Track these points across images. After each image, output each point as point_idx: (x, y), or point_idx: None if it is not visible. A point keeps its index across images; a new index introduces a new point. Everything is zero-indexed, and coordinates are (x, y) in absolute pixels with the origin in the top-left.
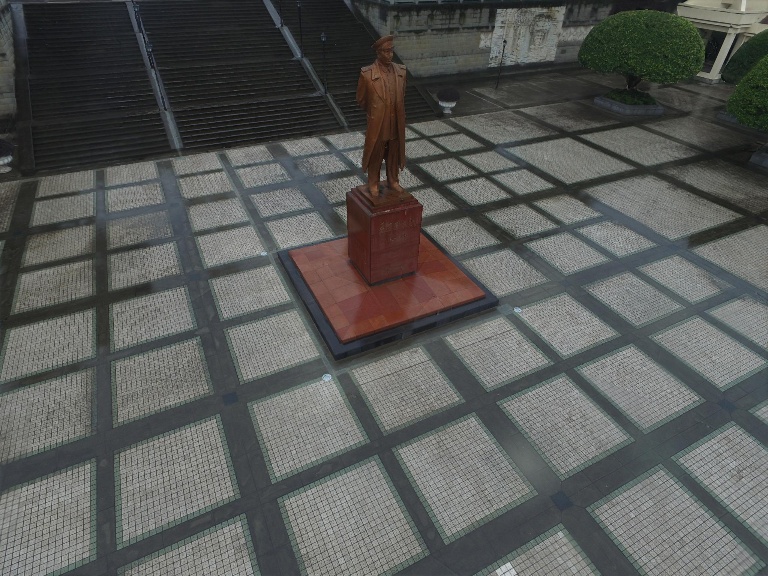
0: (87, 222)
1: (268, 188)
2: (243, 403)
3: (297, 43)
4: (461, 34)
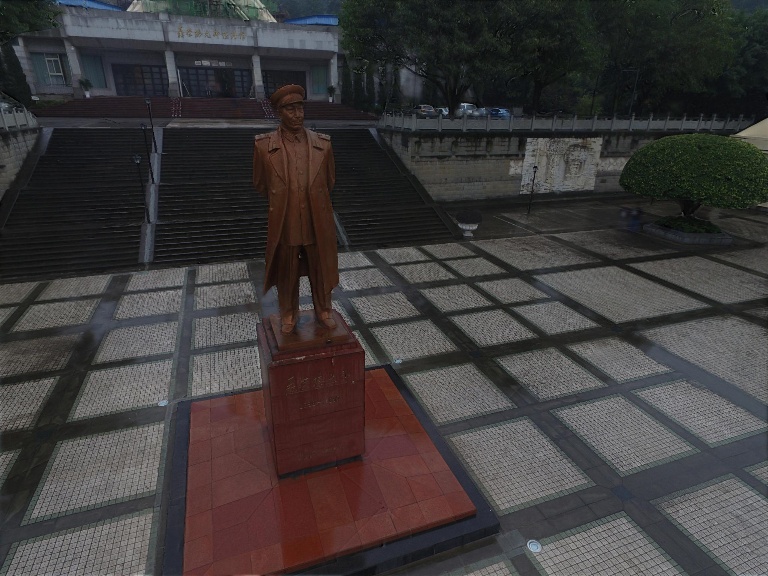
0: None
1: (222, 311)
2: None
3: None
4: (488, 161)
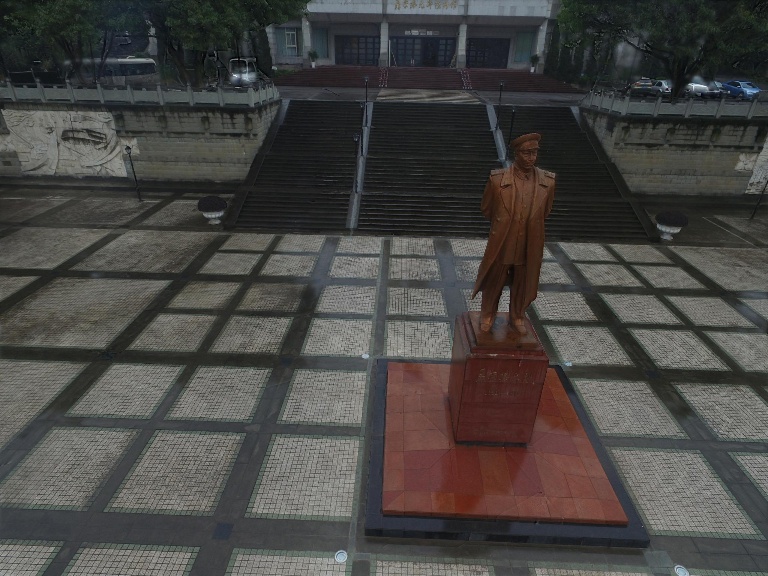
0: (238, 279)
1: (411, 284)
2: (231, 545)
3: (506, 146)
4: (711, 152)
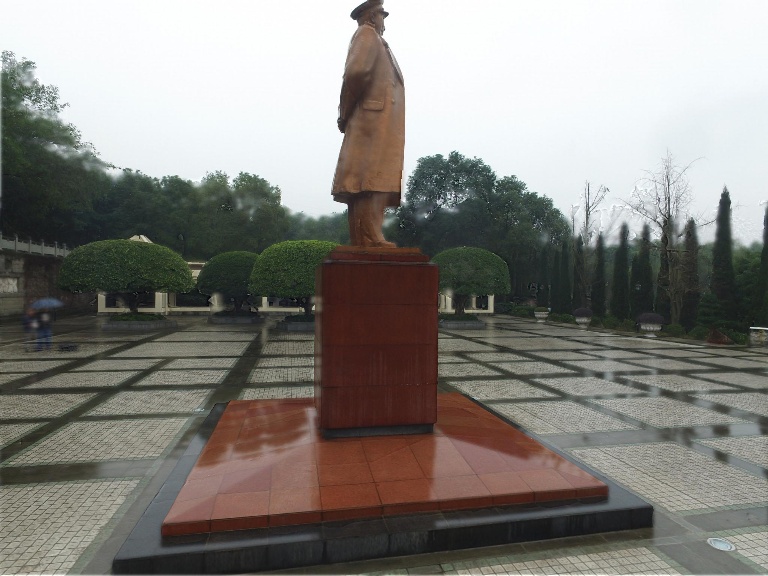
0: None
1: None
2: None
3: None
4: None
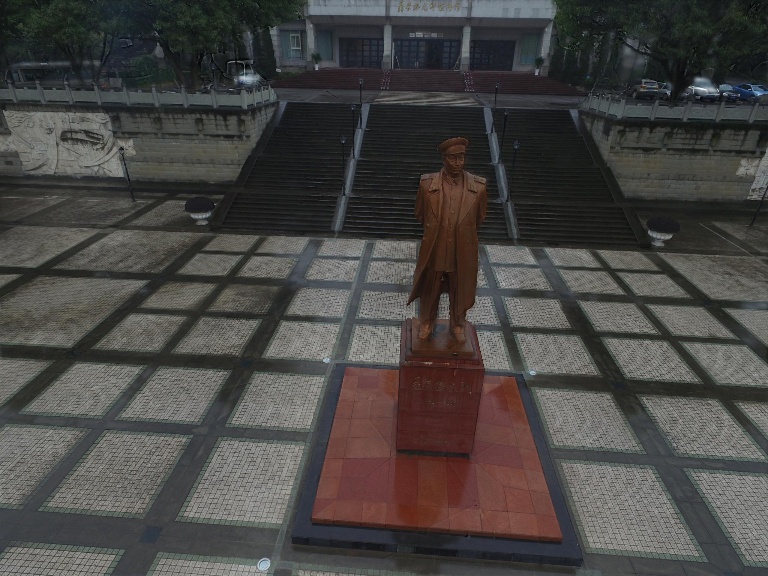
0: (215, 281)
1: (387, 287)
2: (156, 549)
3: None
4: (710, 157)
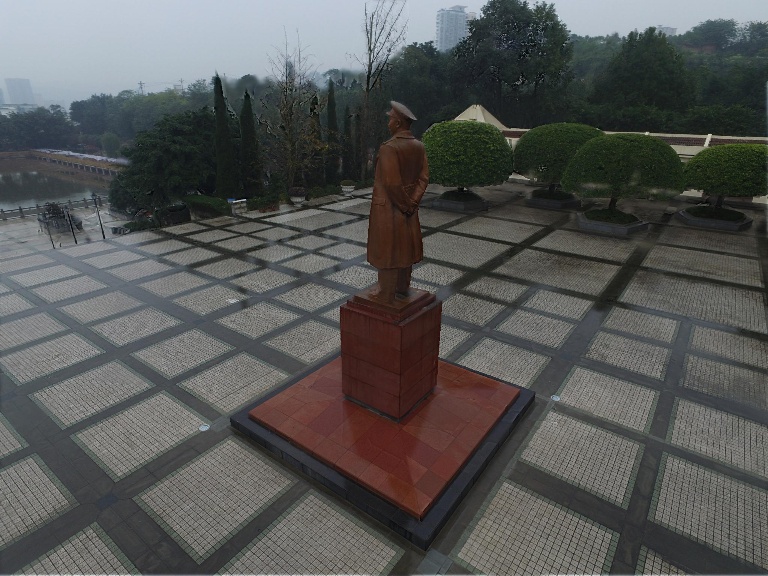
0: None
1: None
2: None
3: None
4: None
